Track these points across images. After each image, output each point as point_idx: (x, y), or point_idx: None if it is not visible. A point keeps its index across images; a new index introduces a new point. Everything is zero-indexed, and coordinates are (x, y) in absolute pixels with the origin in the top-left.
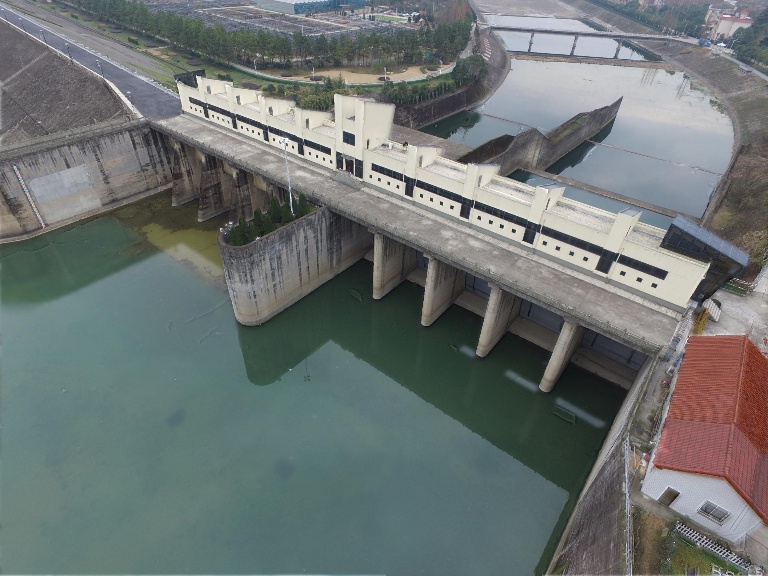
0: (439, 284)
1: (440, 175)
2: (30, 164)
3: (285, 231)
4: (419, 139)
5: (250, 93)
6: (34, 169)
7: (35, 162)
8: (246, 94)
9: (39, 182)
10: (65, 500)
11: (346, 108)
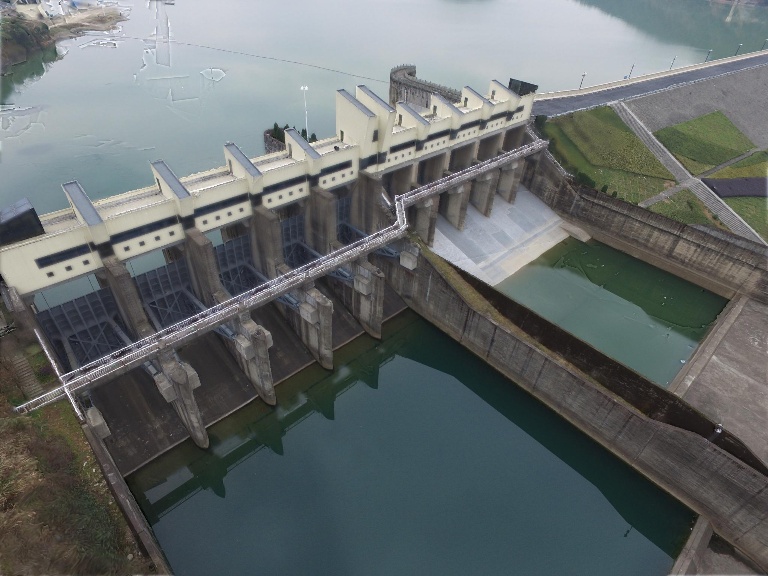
0: (224, 231)
1: (263, 157)
2: (413, 93)
3: (282, 147)
4: (764, 366)
5: (479, 101)
6: (413, 97)
7: (415, 93)
8: (475, 100)
9: (412, 106)
10: (189, 162)
11: (360, 100)
